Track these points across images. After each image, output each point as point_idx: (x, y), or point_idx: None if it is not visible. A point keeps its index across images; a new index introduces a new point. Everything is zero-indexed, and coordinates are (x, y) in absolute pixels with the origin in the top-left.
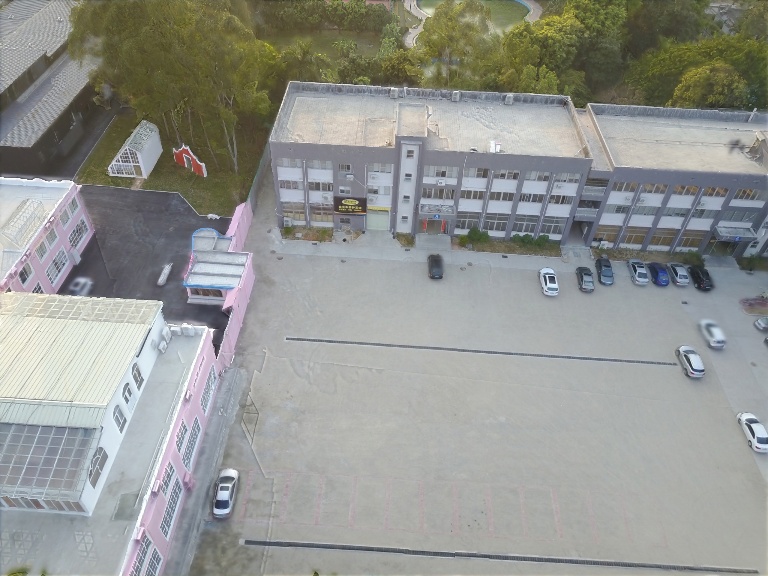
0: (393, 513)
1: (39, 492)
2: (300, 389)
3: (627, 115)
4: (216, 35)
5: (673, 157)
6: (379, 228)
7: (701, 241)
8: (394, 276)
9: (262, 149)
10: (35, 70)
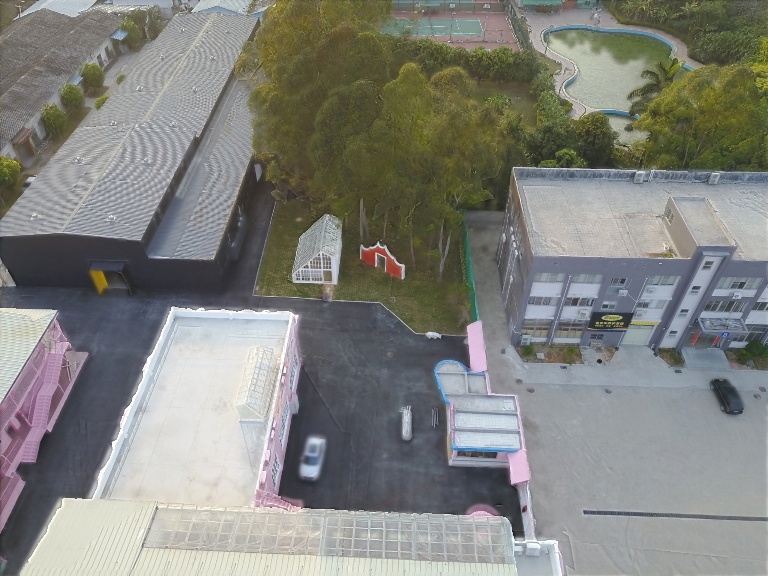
0: None
1: None
2: None
3: None
4: (468, 129)
5: None
6: (634, 343)
7: None
8: (678, 411)
9: (458, 240)
10: (187, 155)
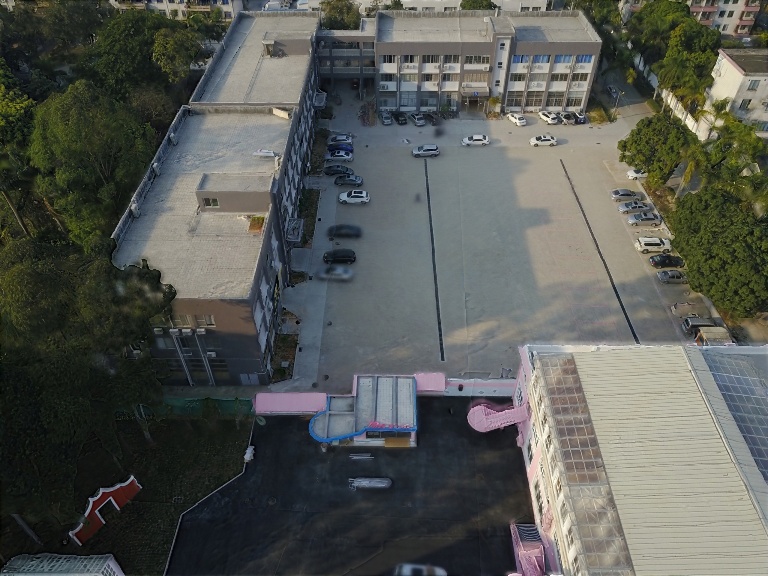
0: (589, 285)
1: (760, 384)
2: (501, 343)
3: (202, 93)
4: None
5: (274, 84)
6: None
7: (313, 121)
8: (350, 287)
9: None
10: None
